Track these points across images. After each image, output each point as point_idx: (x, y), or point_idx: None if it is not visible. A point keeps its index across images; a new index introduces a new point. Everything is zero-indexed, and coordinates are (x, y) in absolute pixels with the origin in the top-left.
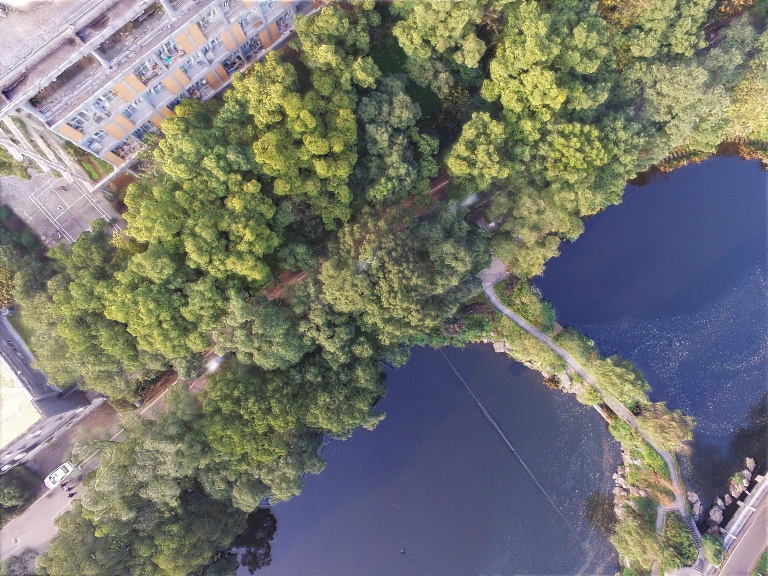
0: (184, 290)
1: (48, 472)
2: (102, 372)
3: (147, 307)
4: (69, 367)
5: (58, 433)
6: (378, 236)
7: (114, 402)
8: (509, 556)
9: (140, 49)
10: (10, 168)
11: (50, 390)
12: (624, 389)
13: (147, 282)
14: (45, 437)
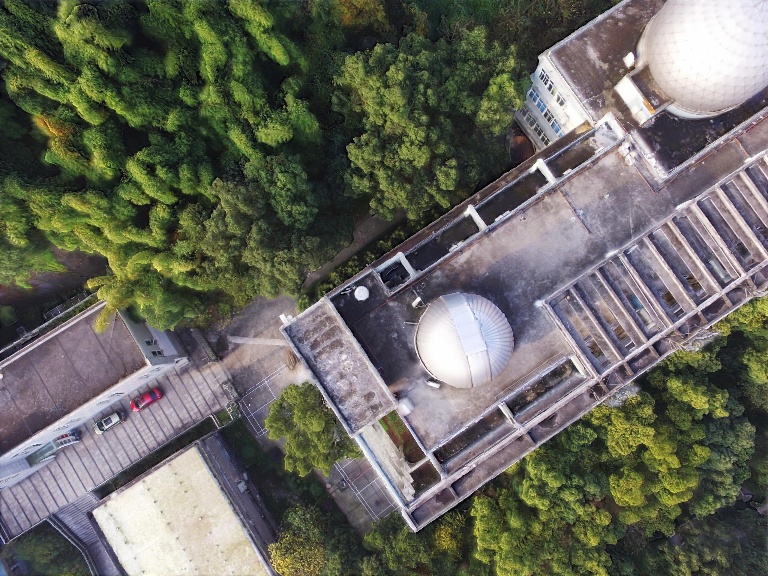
0: None
1: None
2: None
3: None
4: None
5: None
6: None
7: None
8: None
9: None
10: (343, 453)
11: None
12: None
13: None
14: None
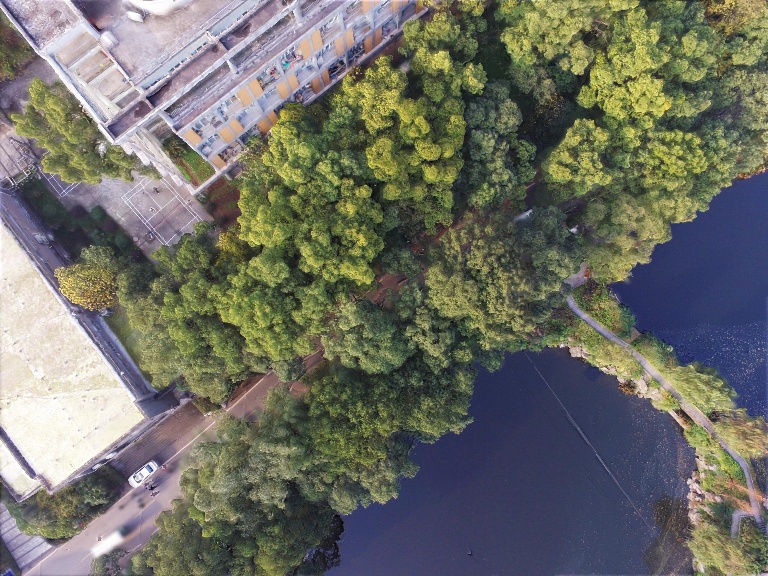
0: (296, 294)
1: (132, 471)
2: (205, 374)
3: (263, 311)
4: (174, 369)
5: (145, 433)
6: (486, 242)
7: (199, 402)
8: (583, 560)
9: (266, 54)
10: (117, 170)
11: (147, 391)
12: (711, 396)
13: (261, 286)
14: (135, 437)
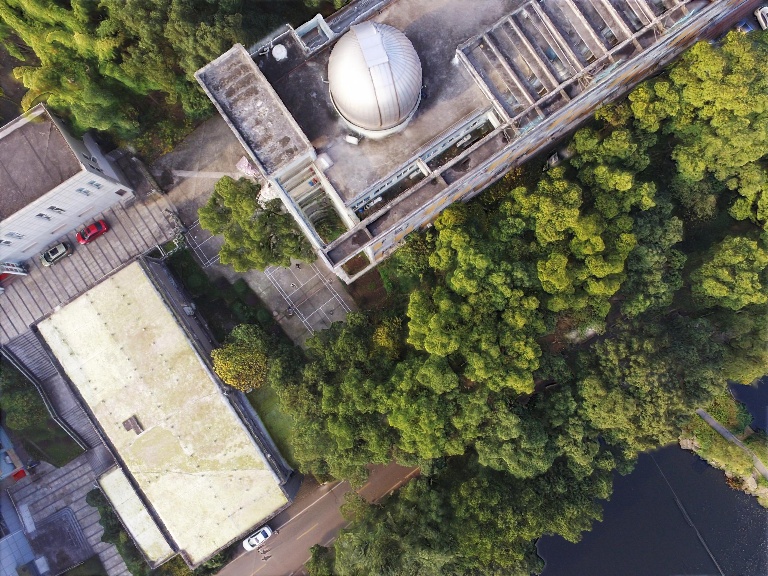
0: (459, 400)
1: None
2: None
3: (430, 418)
4: None
5: None
6: (647, 360)
7: None
8: None
9: None
10: (281, 258)
11: (285, 469)
12: None
13: (427, 391)
14: None
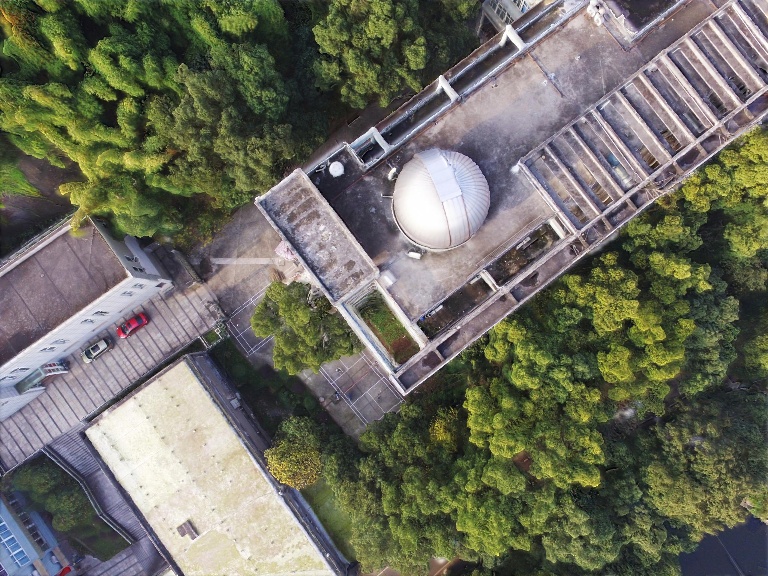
0: (524, 498)
1: None
2: None
3: (498, 521)
4: None
5: None
6: (712, 445)
7: None
8: None
9: None
10: None
11: (343, 564)
12: None
13: (492, 491)
14: None
